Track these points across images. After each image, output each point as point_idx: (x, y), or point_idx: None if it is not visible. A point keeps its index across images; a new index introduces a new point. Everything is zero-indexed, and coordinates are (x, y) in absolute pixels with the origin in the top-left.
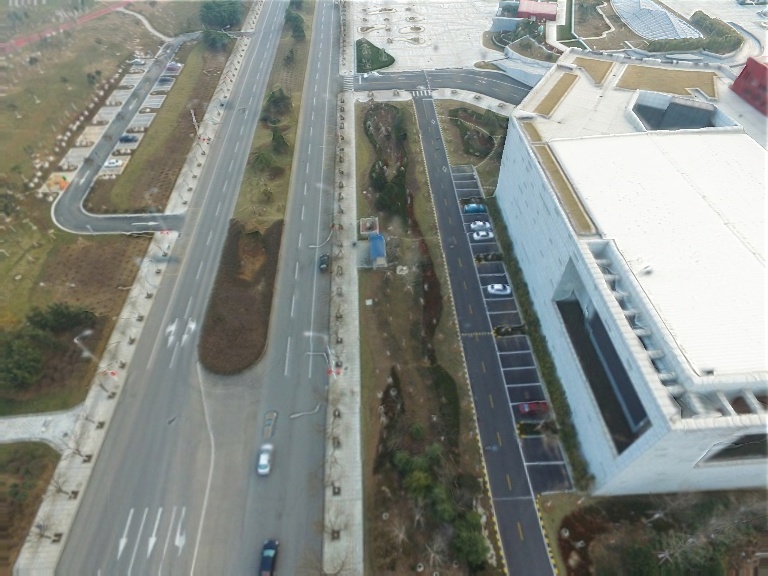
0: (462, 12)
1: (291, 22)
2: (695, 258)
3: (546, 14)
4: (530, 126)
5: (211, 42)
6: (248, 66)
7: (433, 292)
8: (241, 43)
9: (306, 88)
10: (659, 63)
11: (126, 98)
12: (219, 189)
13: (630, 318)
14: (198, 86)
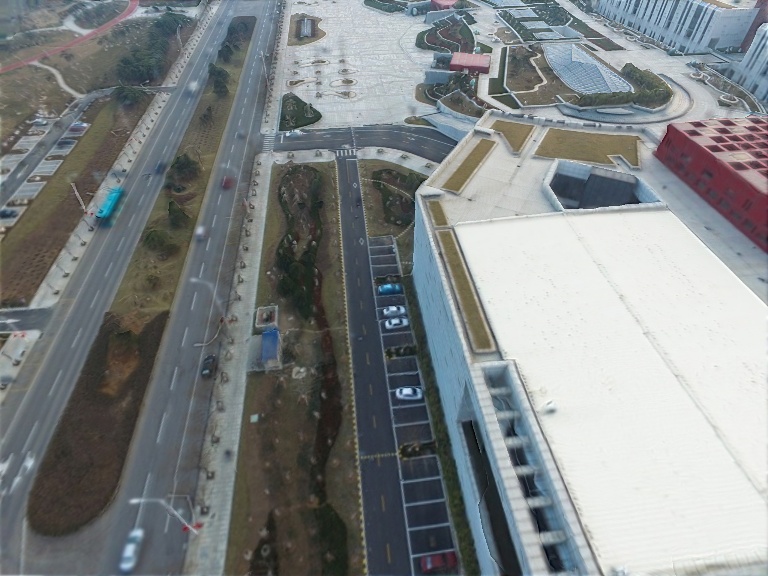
0: (397, 64)
1: (215, 76)
2: (608, 385)
3: (479, 67)
4: (436, 206)
5: (123, 99)
6: (162, 125)
7: (331, 402)
8: (158, 99)
9: (222, 149)
10: (581, 126)
11: (15, 165)
12: (101, 274)
13: (528, 477)
14: (101, 149)
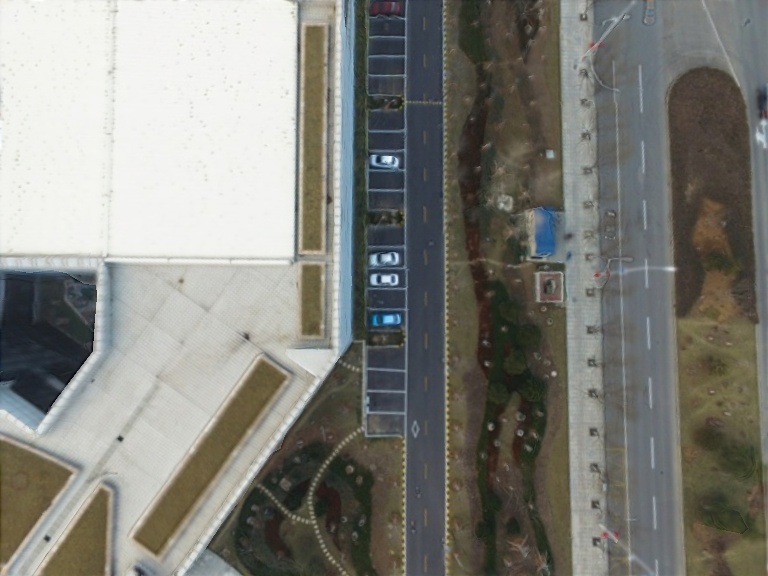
0: None
1: None
2: None
3: None
4: (309, 319)
5: None
6: None
7: (470, 157)
8: None
9: None
10: None
11: None
12: None
13: None
14: None
